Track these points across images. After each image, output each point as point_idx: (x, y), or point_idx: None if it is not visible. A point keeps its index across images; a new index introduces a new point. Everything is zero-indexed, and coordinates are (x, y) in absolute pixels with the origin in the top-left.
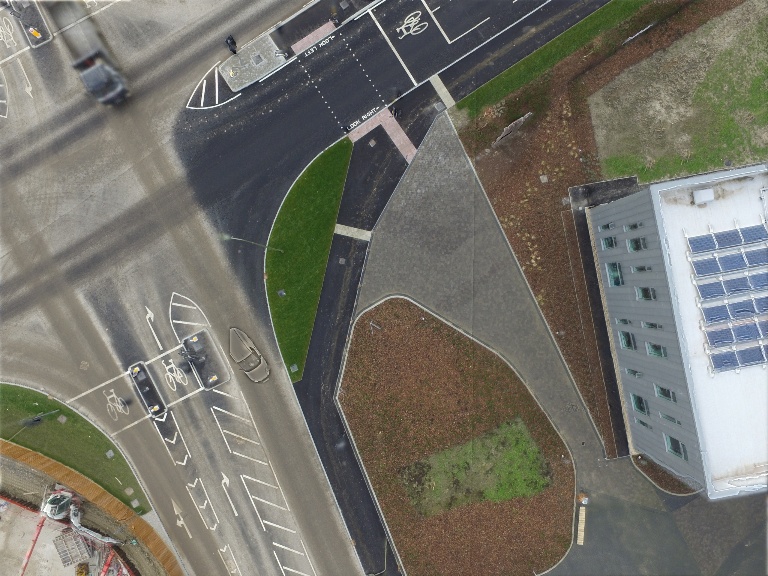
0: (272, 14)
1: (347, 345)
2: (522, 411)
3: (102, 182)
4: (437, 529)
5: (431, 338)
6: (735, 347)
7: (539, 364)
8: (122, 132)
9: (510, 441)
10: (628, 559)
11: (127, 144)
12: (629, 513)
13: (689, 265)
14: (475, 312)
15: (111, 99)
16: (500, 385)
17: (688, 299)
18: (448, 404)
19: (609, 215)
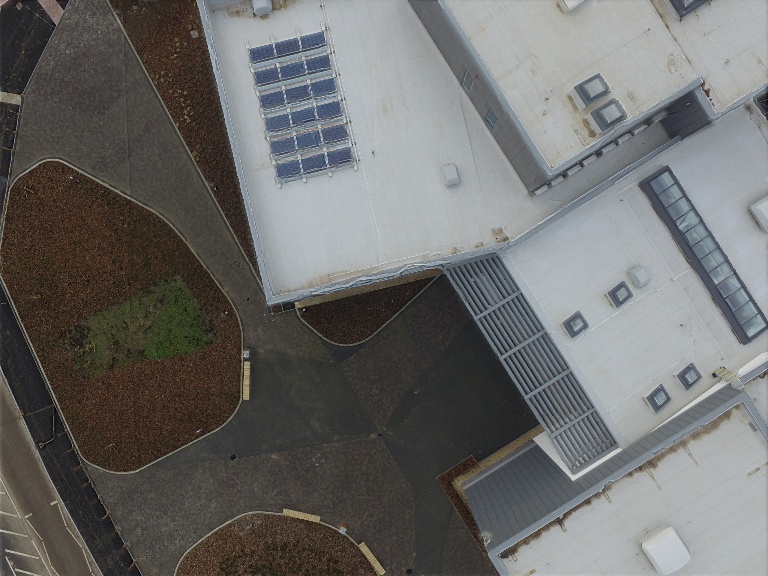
0: None
1: (4, 212)
2: (181, 268)
3: None
4: (100, 392)
5: (84, 199)
6: (300, 156)
7: (199, 221)
8: None
9: (169, 298)
10: (299, 413)
11: None
12: (297, 367)
13: (253, 77)
14: (131, 172)
15: None
16: (157, 243)
17: (253, 111)
18: (103, 264)
19: None
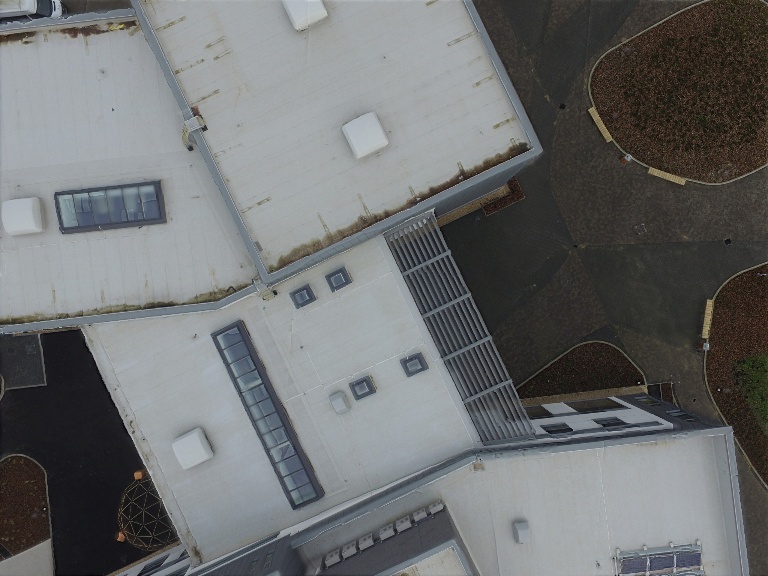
0: None
1: None
2: (762, 441)
3: None
4: None
5: None
6: (674, 571)
7: None
8: None
9: None
10: (656, 279)
11: None
12: (652, 326)
13: None
14: None
15: None
16: None
17: None
18: None
19: None
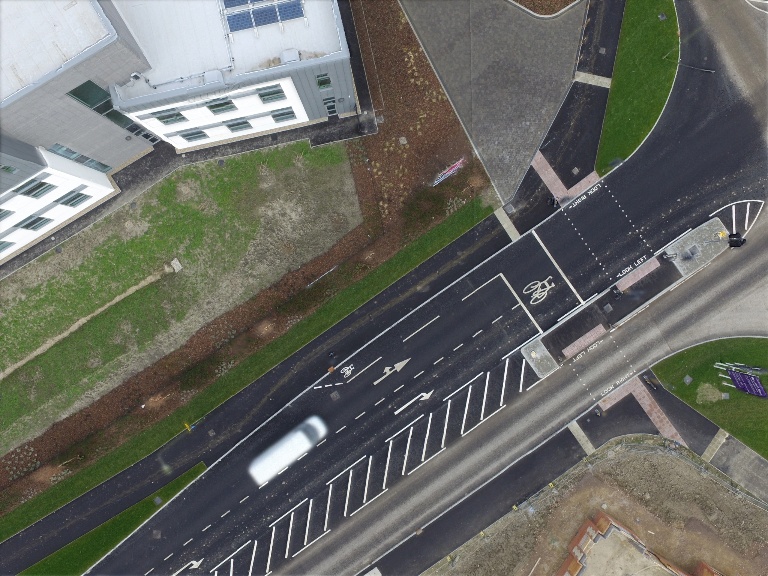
0: (680, 298)
1: None
2: None
3: None
4: None
5: None
6: None
7: None
8: None
9: None
10: None
11: None
12: None
13: None
14: (467, 4)
15: None
16: None
17: None
18: None
19: None
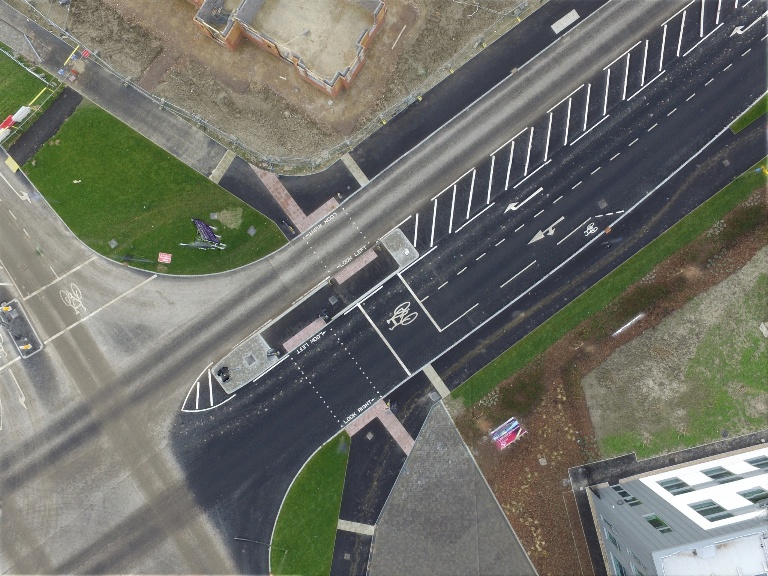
0: (262, 312)
1: None
2: None
3: (101, 491)
4: None
5: None
6: None
7: None
8: (118, 439)
9: None
10: None
11: (124, 451)
12: None
13: None
14: None
15: (105, 406)
16: None
17: None
18: None
19: (611, 520)
